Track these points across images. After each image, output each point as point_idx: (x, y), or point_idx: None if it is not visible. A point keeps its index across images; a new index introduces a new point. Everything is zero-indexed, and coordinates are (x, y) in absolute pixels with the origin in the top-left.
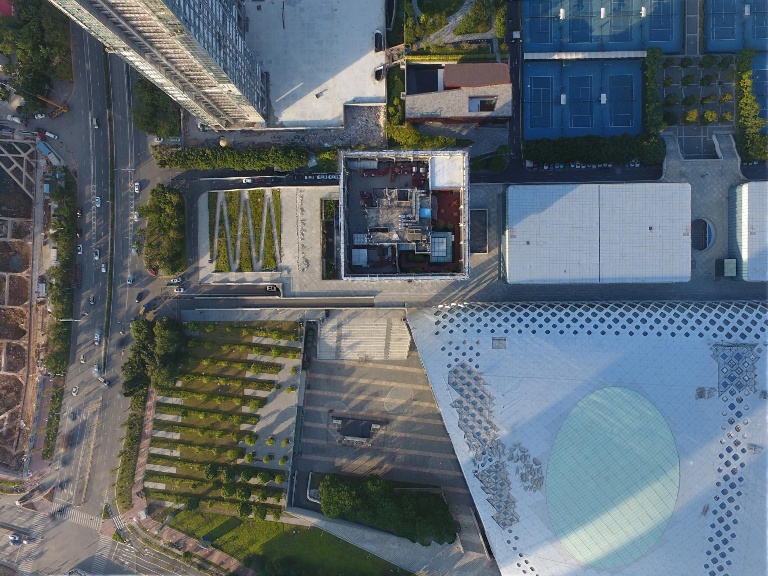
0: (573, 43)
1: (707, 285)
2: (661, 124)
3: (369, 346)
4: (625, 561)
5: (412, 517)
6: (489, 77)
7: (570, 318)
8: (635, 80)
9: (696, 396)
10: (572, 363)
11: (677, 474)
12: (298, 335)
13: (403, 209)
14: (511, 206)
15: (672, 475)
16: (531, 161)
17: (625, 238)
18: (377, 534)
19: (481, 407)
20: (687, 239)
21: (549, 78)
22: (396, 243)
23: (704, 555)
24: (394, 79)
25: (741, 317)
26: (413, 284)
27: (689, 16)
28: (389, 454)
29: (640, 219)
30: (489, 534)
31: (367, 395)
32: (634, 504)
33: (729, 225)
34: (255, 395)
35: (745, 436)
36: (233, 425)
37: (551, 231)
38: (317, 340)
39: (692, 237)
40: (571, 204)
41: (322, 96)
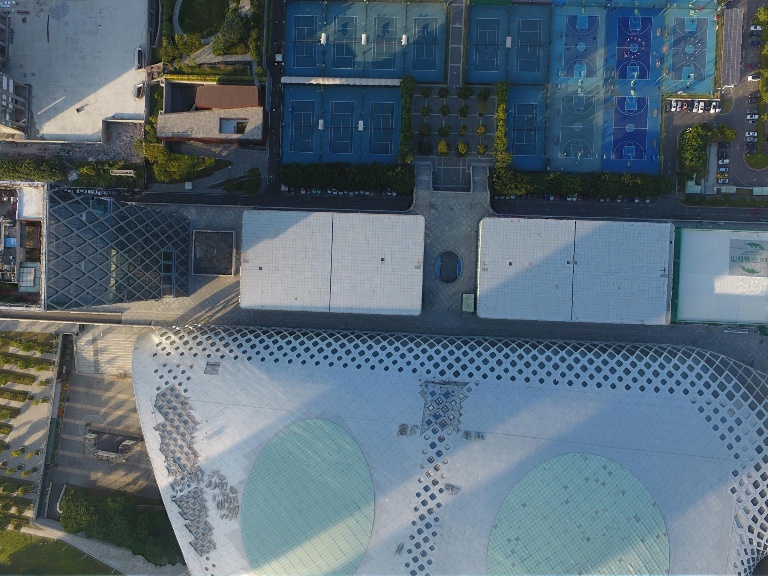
0: (336, 68)
1: (452, 319)
2: (407, 154)
3: (126, 362)
4: None
5: (145, 536)
6: (239, 99)
7: (290, 346)
8: (396, 108)
9: (398, 433)
10: (279, 392)
11: (372, 511)
12: (53, 347)
13: None
14: (245, 230)
15: (366, 511)
16: (284, 185)
17: (357, 268)
18: (122, 550)
19: (184, 432)
20: (419, 272)
21: (311, 102)
22: None
23: None
24: (154, 97)
25: (461, 354)
26: (160, 303)
27: (453, 46)
28: (144, 471)
29: (372, 250)
30: (188, 560)
31: (125, 410)
32: (326, 538)
33: (476, 259)
34: (9, 405)
35: (444, 476)
36: None
37: (283, 257)
38: None
39: (447, 269)
40: (304, 231)
41: (83, 111)
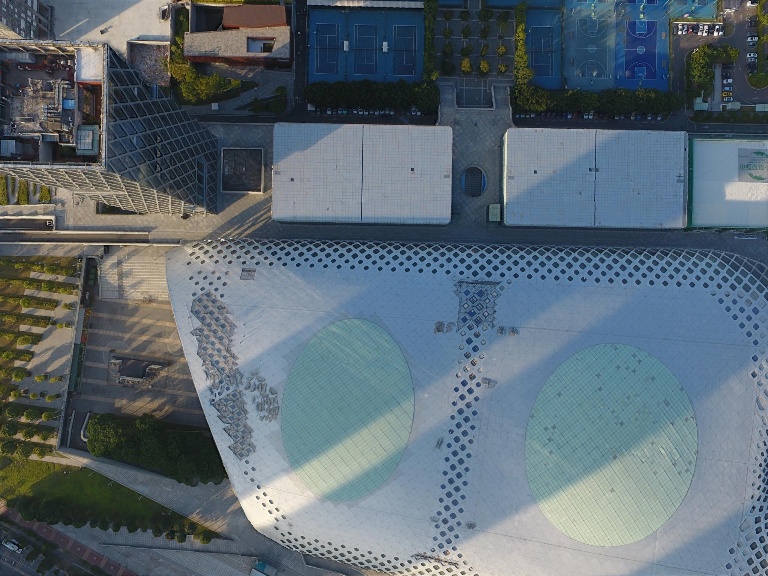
0: None
1: (478, 231)
2: (432, 71)
3: (152, 286)
4: (361, 494)
5: (176, 455)
6: (266, 18)
7: (324, 253)
8: (418, 31)
9: (435, 330)
10: (316, 295)
11: (411, 406)
12: (76, 271)
13: (48, 100)
14: (276, 143)
15: (406, 407)
16: (311, 104)
17: (387, 178)
18: (150, 476)
19: (221, 336)
20: (448, 181)
21: (335, 25)
22: (39, 133)
23: (439, 489)
24: (179, 19)
25: (492, 257)
26: (189, 221)
27: None
28: (170, 396)
29: (402, 160)
30: (226, 465)
31: (150, 336)
32: (367, 435)
33: (500, 173)
34: (30, 331)
35: (481, 370)
36: (7, 361)
37: (315, 169)
38: (97, 277)
39: (471, 186)
40: (335, 143)
41: (107, 32)
